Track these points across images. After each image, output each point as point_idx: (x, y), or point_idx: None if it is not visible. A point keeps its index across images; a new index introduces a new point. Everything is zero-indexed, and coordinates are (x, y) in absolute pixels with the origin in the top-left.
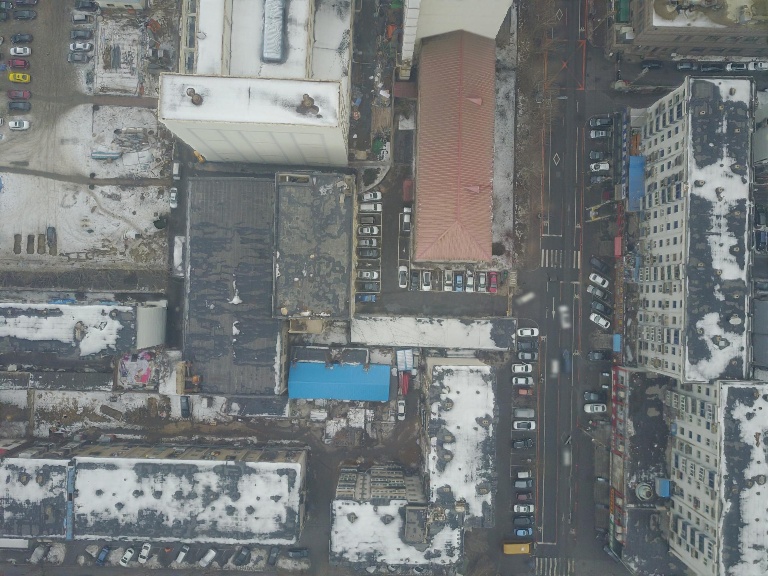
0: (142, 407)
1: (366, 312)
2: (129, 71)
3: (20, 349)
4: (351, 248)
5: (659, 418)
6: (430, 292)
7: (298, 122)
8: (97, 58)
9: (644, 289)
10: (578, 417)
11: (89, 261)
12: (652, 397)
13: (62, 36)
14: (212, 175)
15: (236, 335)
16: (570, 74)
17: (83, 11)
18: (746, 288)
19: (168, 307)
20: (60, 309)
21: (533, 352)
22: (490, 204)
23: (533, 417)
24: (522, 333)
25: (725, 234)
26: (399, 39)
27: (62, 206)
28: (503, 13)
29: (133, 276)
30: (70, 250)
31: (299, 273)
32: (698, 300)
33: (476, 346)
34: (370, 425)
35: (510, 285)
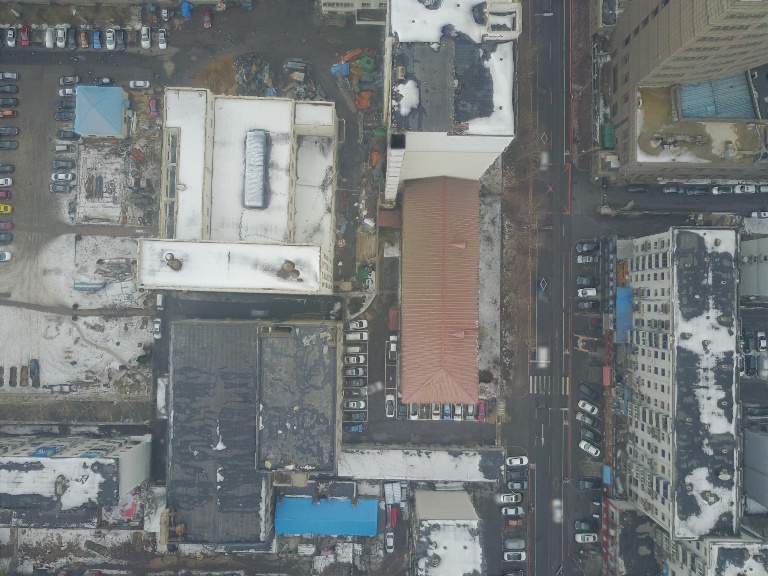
0: (127, 541)
1: (353, 442)
2: (111, 200)
3: (0, 504)
4: (335, 400)
5: (650, 557)
6: (418, 421)
7: (278, 287)
8: (79, 187)
9: (633, 423)
10: (569, 546)
11: (72, 393)
12: (643, 535)
13: (44, 166)
14: (196, 305)
15: (220, 482)
16: (556, 198)
17: (65, 140)
18: (735, 442)
19: (153, 440)
20: (41, 462)
21: (522, 481)
22: (476, 347)
23: (523, 548)
24: (511, 462)
25: (712, 387)
26: (383, 167)
27: (45, 338)
28: (485, 167)
29: (117, 408)
30: (53, 382)
31: (283, 425)
32: (686, 455)
33: (464, 478)
34: (358, 557)
35: (498, 415)
